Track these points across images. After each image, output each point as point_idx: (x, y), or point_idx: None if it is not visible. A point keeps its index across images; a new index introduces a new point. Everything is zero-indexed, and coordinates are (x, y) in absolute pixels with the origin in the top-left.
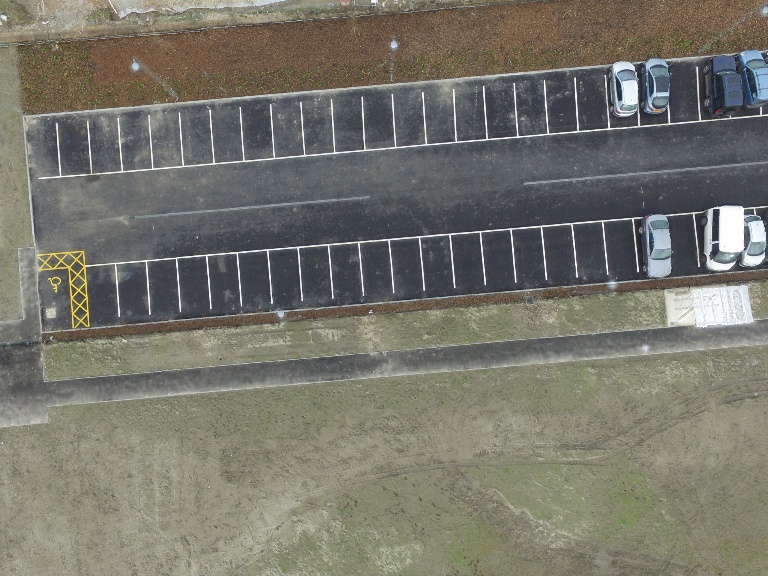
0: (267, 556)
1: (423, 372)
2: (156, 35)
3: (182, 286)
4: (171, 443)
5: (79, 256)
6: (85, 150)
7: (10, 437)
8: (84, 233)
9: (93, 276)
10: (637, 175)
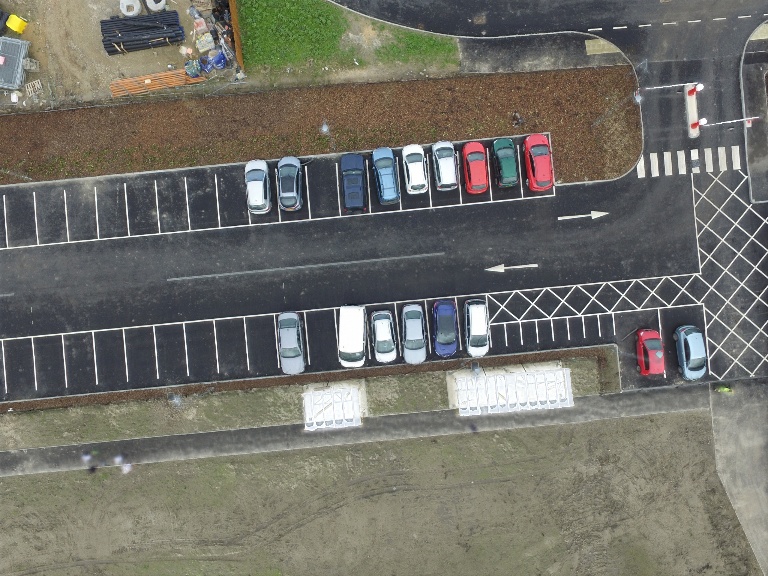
0: None
1: (64, 469)
2: None
3: None
4: None
5: None
6: None
7: None
8: None
9: None
10: (279, 270)
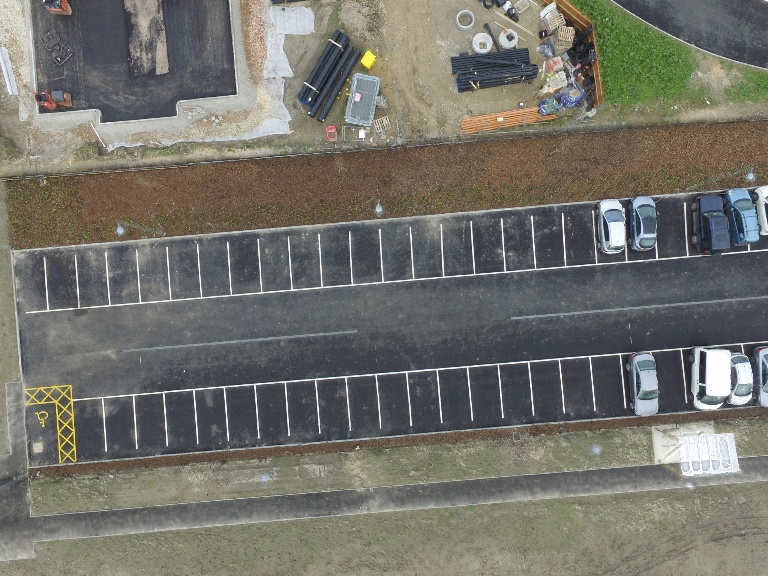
0: None
1: (410, 508)
2: (144, 170)
3: (169, 420)
4: None
5: (66, 390)
6: (73, 284)
7: None
8: (71, 367)
9: (80, 410)
10: (625, 310)
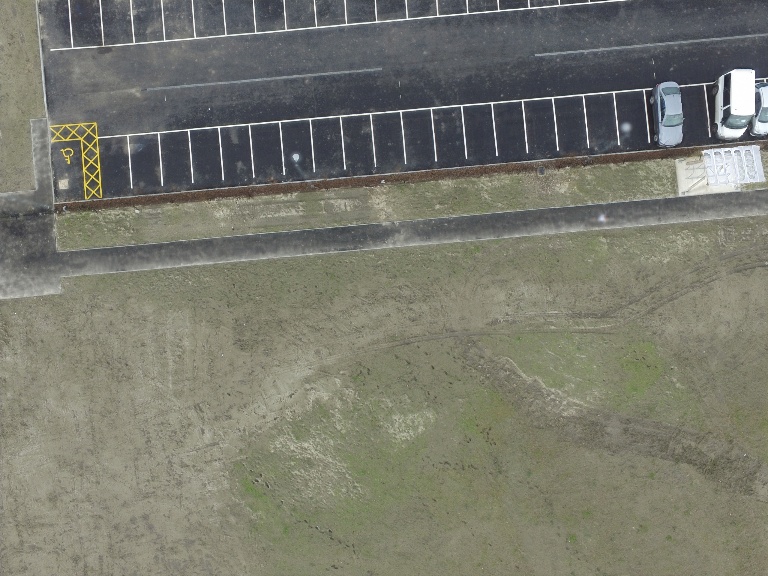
0: (280, 423)
1: (435, 242)
2: None
3: (194, 157)
4: (184, 312)
5: (91, 128)
6: (97, 22)
7: (23, 307)
8: (96, 105)
9: (105, 148)
10: (648, 46)
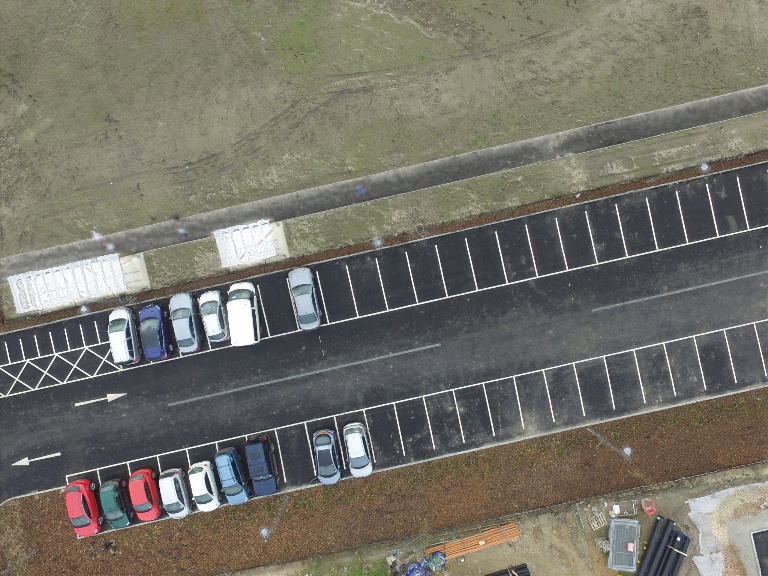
0: None
1: (517, 144)
2: None
3: None
4: (761, 37)
5: None
6: None
7: None
8: None
9: None
10: (330, 368)
